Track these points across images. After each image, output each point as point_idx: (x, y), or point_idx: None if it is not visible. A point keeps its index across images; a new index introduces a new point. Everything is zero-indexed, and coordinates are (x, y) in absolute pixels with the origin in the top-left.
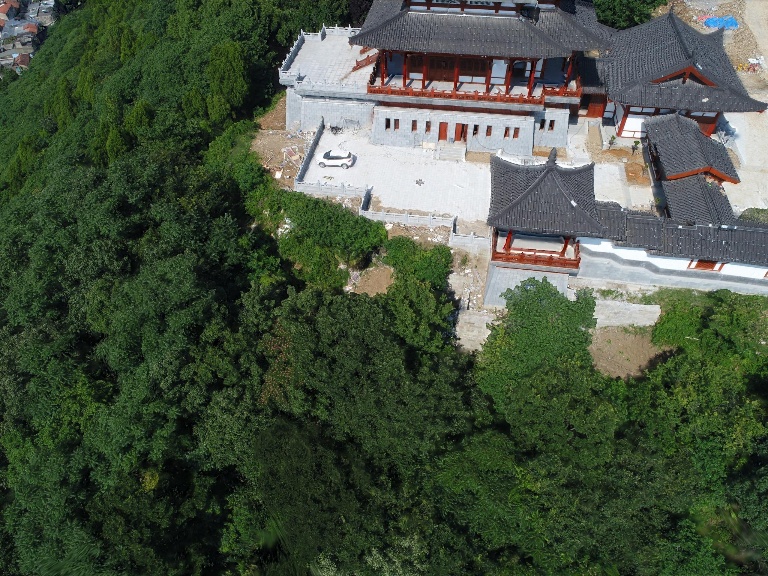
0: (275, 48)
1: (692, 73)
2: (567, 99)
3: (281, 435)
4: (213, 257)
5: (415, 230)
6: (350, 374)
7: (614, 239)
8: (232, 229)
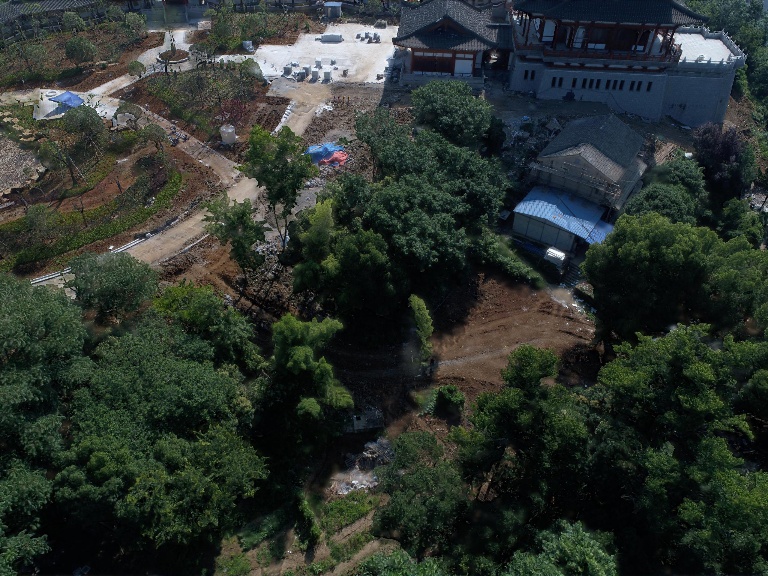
0: None
1: None
2: None
3: None
4: None
5: None
6: None
7: None
8: None
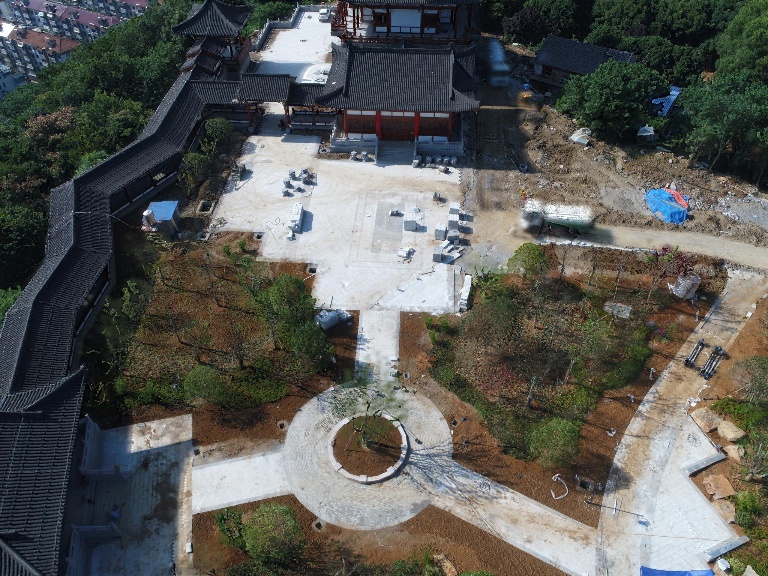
0: (577, 34)
1: None
2: None
3: None
4: (245, 0)
5: (255, 39)
6: None
7: None
8: None
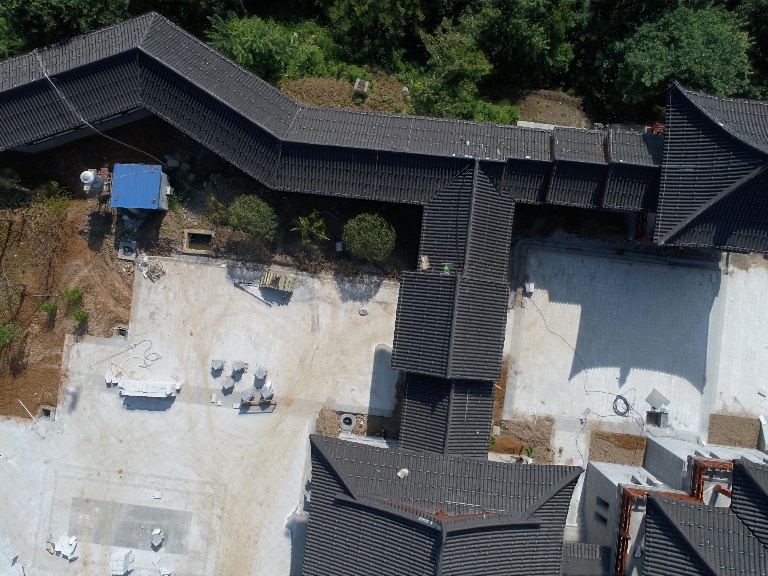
0: None
1: None
2: (645, 488)
3: None
4: None
5: None
6: None
7: (625, 131)
8: None
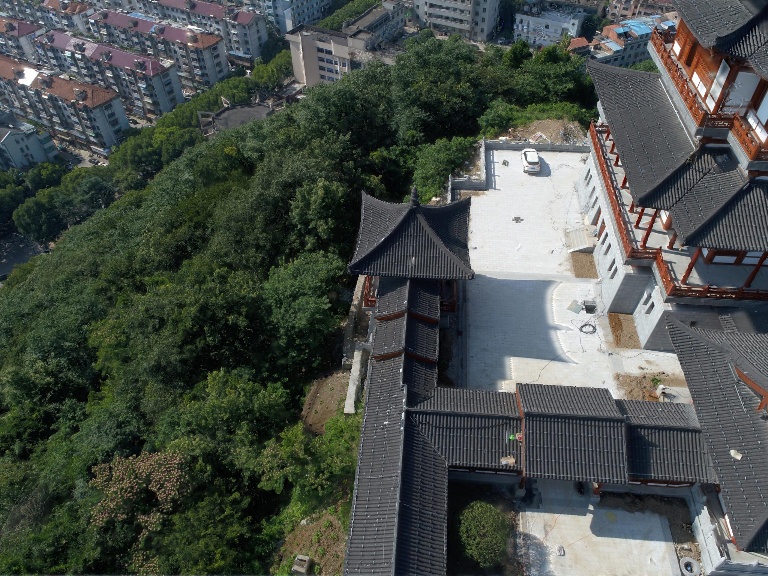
0: None
1: (767, 408)
2: None
3: (240, 180)
4: (391, 123)
5: None
6: (261, 183)
7: None
8: (413, 119)
